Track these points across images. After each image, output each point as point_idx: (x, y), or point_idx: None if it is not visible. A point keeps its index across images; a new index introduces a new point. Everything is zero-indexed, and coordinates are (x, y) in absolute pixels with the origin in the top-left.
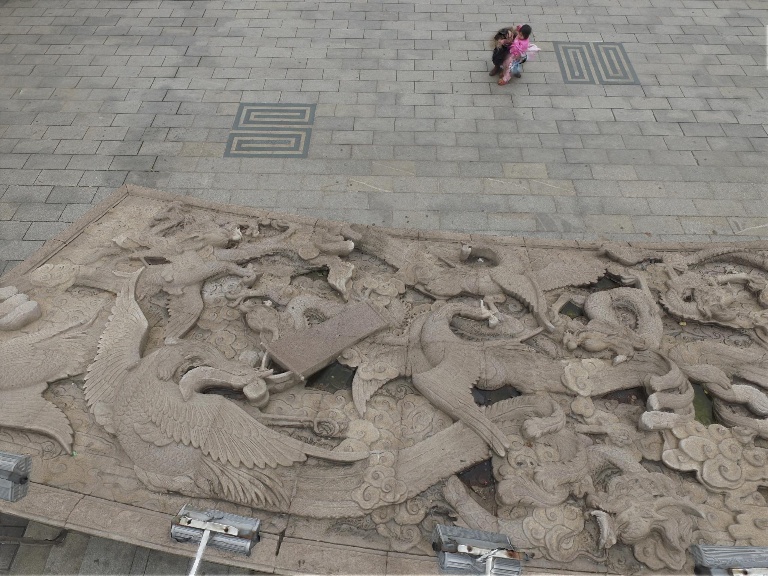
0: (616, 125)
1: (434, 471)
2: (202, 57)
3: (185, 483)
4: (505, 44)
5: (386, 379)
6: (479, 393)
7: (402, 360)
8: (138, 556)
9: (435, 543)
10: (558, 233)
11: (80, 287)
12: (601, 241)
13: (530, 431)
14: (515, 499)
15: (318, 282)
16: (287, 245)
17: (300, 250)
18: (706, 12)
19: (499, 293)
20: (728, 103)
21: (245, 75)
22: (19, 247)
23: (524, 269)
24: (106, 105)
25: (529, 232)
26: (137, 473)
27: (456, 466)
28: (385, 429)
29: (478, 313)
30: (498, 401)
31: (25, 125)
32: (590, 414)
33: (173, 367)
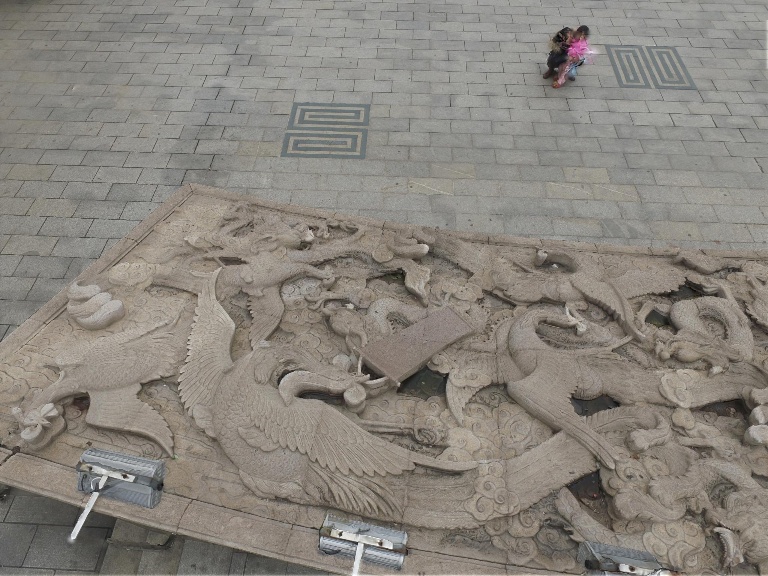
0: (675, 130)
1: (544, 483)
2: (252, 56)
3: (294, 490)
4: (563, 47)
5: (479, 386)
6: (576, 403)
7: (492, 367)
8: (235, 562)
9: (588, 561)
10: (625, 239)
11: (158, 287)
12: (674, 248)
13: (638, 443)
14: (633, 514)
15: (393, 285)
16: (360, 247)
17: (374, 253)
18: (758, 17)
19: (581, 300)
20: None
21: (297, 74)
22: (82, 244)
23: (602, 276)
24: (159, 103)
25: (595, 238)
26: (243, 478)
27: (566, 478)
28: (484, 438)
29: (565, 320)
30: (596, 411)
31: (80, 122)
32: (692, 426)
33: (269, 370)
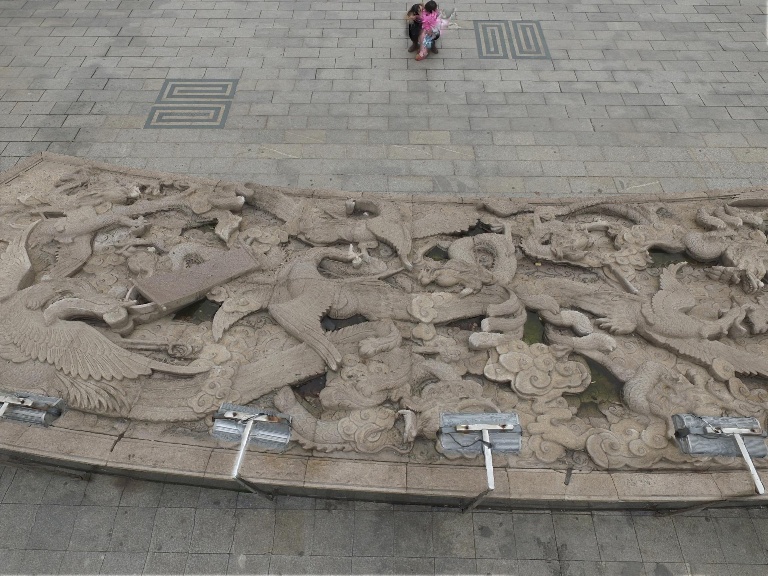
0: (522, 96)
1: (269, 383)
2: (134, 37)
3: None
4: (417, 20)
5: (247, 311)
6: (331, 322)
7: (267, 296)
8: (7, 469)
9: None
10: (452, 193)
11: None
12: None
13: (363, 348)
14: (334, 402)
15: (208, 234)
16: (183, 202)
17: (194, 205)
18: None
19: (373, 240)
20: (632, 75)
21: (173, 53)
22: None
23: None
24: (36, 82)
25: (425, 192)
26: None
27: (290, 378)
28: (238, 352)
29: (344, 255)
30: None
31: None
32: (429, 338)
33: (43, 299)
